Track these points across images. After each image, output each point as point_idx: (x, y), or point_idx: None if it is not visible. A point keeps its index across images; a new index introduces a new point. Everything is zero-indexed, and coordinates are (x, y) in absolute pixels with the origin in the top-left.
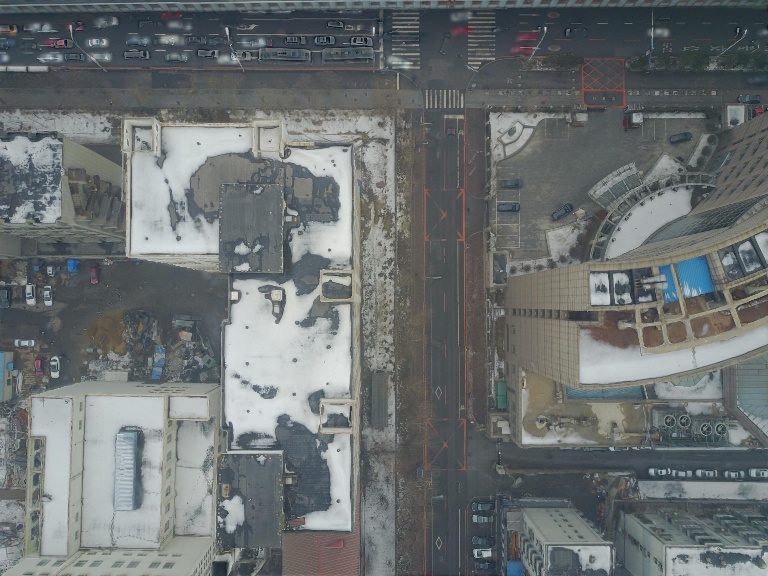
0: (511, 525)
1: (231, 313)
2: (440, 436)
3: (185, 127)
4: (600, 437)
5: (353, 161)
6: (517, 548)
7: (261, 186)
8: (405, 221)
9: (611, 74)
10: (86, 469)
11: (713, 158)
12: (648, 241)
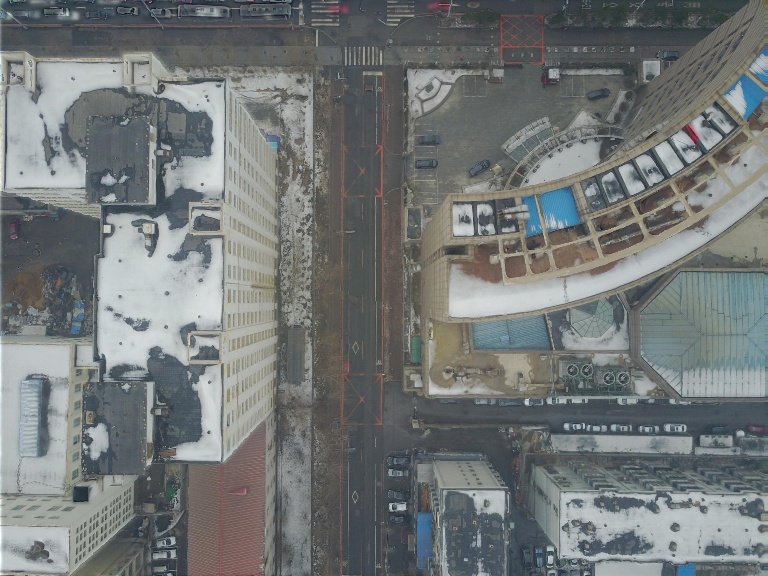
0: (421, 477)
1: (104, 246)
2: (357, 391)
3: (59, 62)
4: (507, 388)
5: (225, 96)
6: (429, 500)
7: (128, 118)
8: (323, 177)
9: (530, 31)
10: None
11: (630, 114)
12: None
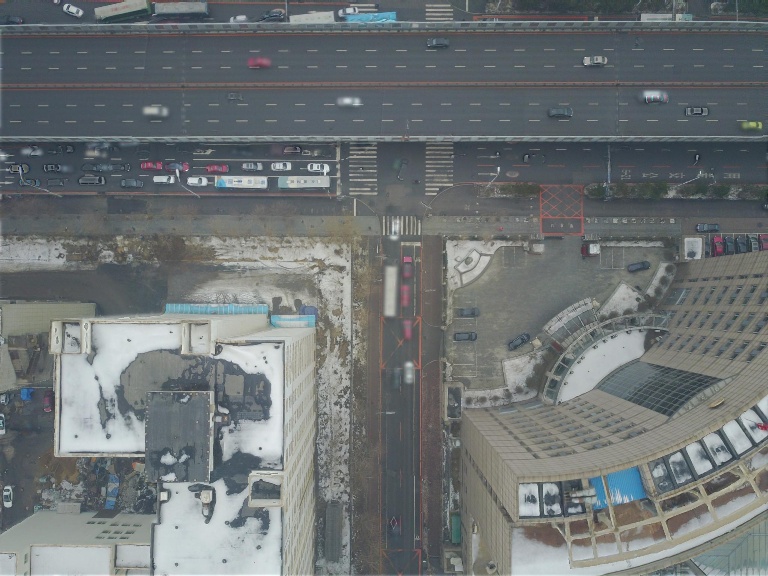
0: None
1: (160, 513)
2: (395, 567)
3: (115, 323)
4: None
5: (284, 359)
6: None
7: (188, 394)
8: (361, 349)
9: (569, 201)
10: None
11: (671, 289)
12: (600, 385)
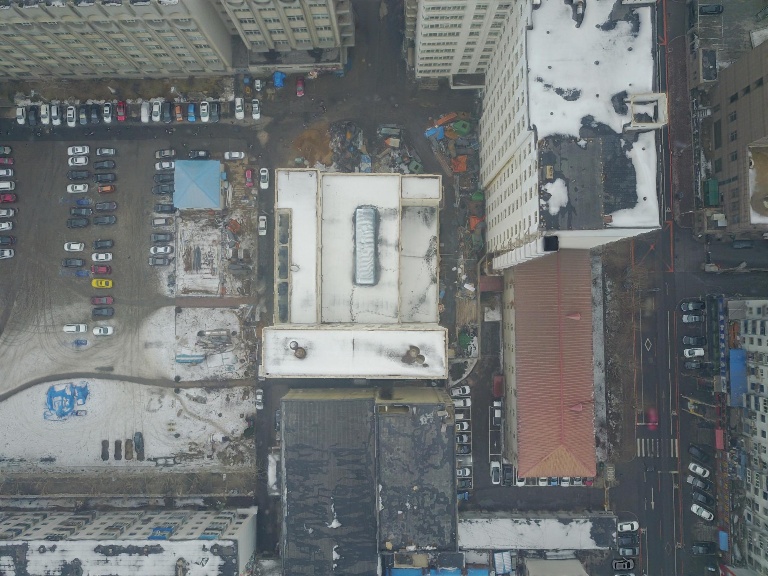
0: (733, 313)
1: (532, 18)
2: None
3: None
4: None
5: None
6: (735, 340)
7: None
8: None
9: None
10: (324, 247)
11: None
12: None
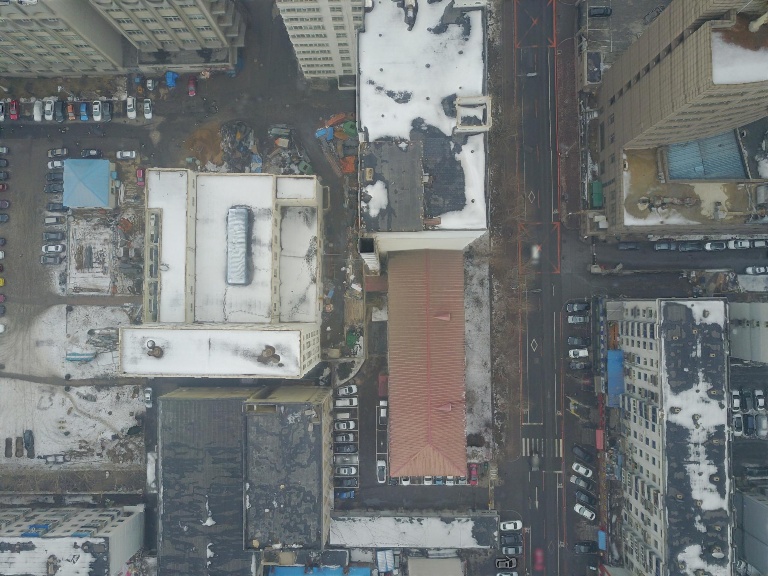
0: (611, 315)
1: (365, 21)
2: None
3: None
4: (703, 218)
5: None
6: (616, 341)
7: None
8: (496, 29)
9: None
10: (198, 247)
11: None
12: None
